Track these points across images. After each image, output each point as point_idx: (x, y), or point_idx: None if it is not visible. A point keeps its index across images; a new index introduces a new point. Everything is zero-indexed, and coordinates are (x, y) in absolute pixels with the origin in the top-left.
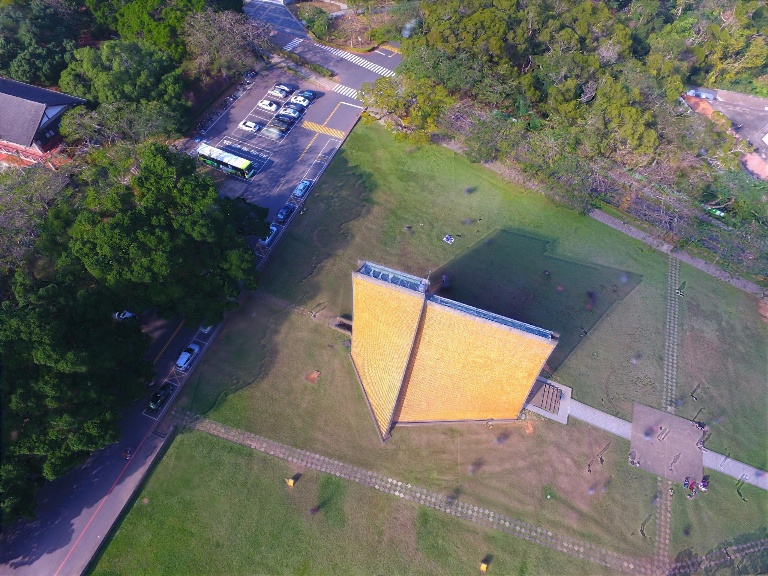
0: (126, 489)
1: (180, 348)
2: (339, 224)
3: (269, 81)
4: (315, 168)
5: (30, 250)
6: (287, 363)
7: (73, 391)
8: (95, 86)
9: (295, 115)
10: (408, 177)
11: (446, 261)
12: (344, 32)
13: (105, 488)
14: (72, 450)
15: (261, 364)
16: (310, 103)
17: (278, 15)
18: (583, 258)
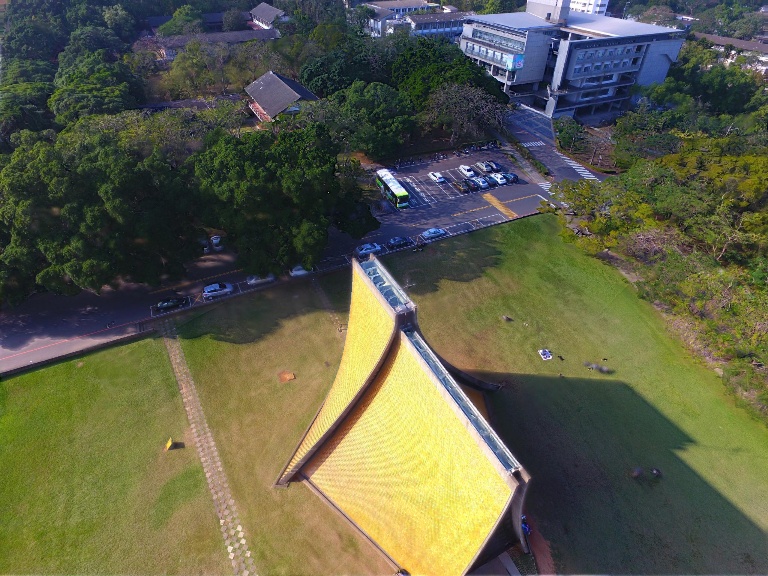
0: (81, 345)
1: (221, 282)
2: (440, 277)
3: (486, 158)
4: (461, 226)
5: (184, 144)
6: (279, 350)
7: (103, 231)
8: (345, 103)
9: (483, 185)
10: (551, 278)
11: (521, 371)
12: (586, 145)
13: (74, 335)
14: (66, 272)
15: (259, 335)
16: (507, 184)
17: (539, 123)
18: (740, 497)
